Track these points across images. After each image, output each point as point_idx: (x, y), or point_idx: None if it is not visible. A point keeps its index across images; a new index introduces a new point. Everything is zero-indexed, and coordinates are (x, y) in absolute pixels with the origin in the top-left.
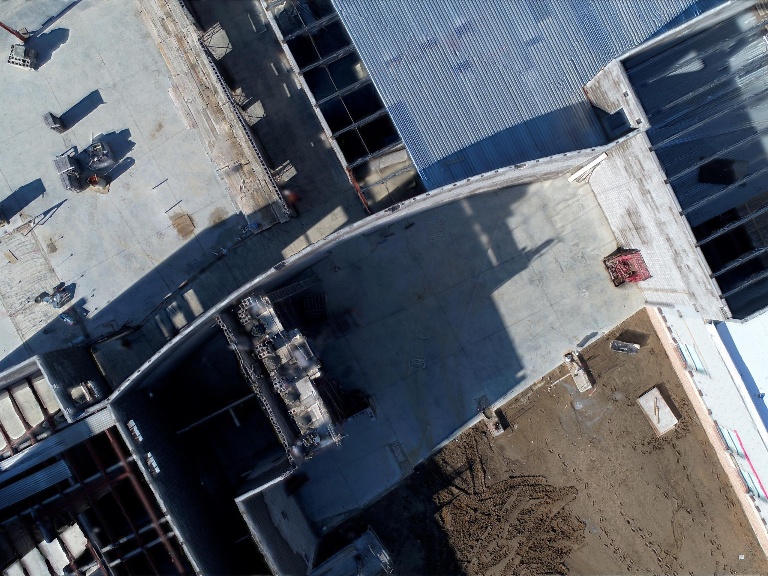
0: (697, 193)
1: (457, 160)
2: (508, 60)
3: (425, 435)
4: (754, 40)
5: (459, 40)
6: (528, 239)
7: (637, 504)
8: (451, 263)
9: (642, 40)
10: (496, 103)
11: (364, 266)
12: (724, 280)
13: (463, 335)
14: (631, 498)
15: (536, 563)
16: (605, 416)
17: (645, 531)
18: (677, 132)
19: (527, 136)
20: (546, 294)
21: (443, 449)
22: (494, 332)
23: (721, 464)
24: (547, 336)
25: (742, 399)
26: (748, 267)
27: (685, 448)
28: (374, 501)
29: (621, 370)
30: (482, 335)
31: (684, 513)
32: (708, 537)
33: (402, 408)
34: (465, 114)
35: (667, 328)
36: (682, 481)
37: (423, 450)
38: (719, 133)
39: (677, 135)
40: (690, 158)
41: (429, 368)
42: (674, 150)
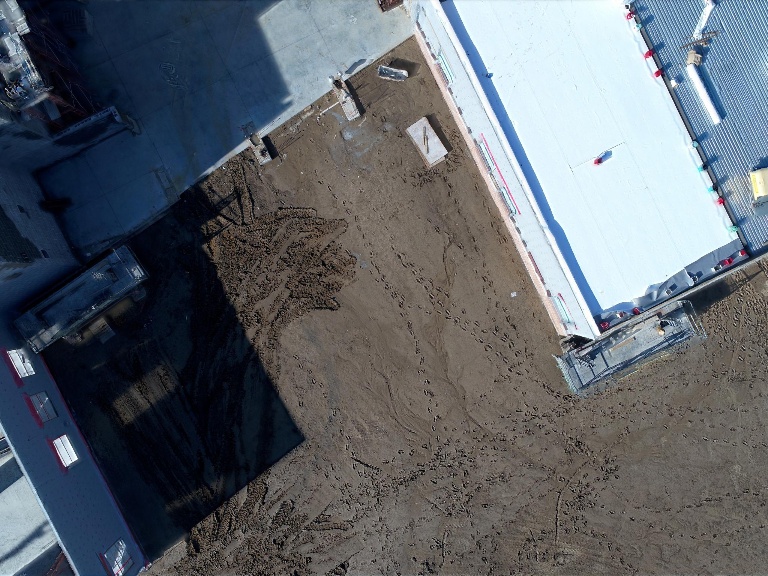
0: None
1: None
2: None
3: (191, 161)
4: None
5: None
6: None
7: (408, 238)
8: None
9: None
10: None
11: None
12: None
13: (230, 60)
14: (402, 232)
15: (306, 297)
16: (375, 147)
17: (416, 266)
18: None
19: None
20: (314, 19)
21: (210, 177)
22: (261, 57)
23: (492, 198)
24: (315, 62)
25: (468, 77)
26: None
27: (456, 181)
28: (141, 230)
29: (391, 100)
30: (249, 60)
31: (456, 248)
32: (480, 273)
33: (168, 134)
34: None
35: (426, 44)
36: (453, 215)
37: (189, 177)
38: None
39: None
40: None
41: (196, 93)
42: None
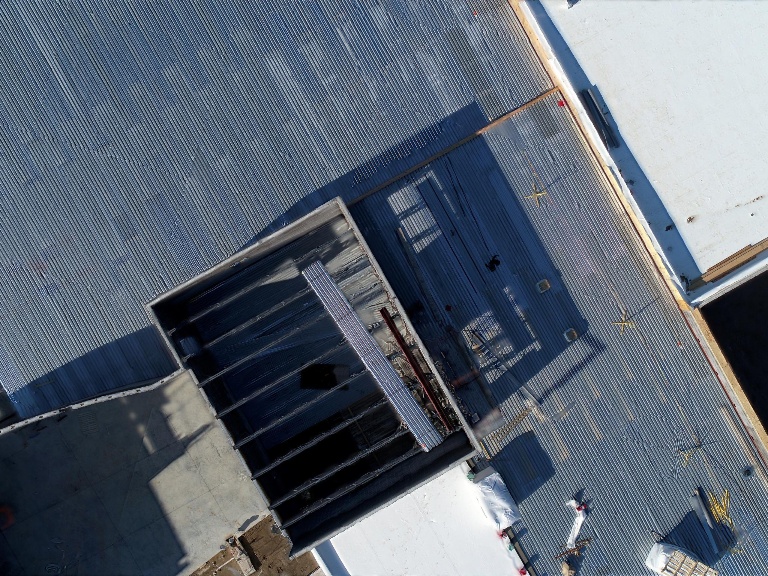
0: (300, 399)
1: (47, 382)
2: (96, 279)
3: None
4: (347, 246)
5: (45, 262)
6: (183, 425)
7: None
8: (106, 453)
9: (231, 253)
10: (86, 323)
11: (18, 460)
12: (287, 509)
13: (122, 525)
14: None
15: None
16: None
17: None
18: (223, 368)
19: (119, 354)
20: (204, 480)
21: None
22: (153, 520)
23: None
24: (207, 522)
25: None
26: (355, 471)
27: None
28: None
29: (286, 551)
30: (141, 524)
31: None
32: None
33: None
34: (54, 336)
35: None
36: None
37: None
38: (318, 339)
39: (222, 372)
40: (291, 365)
41: (89, 560)
42: (274, 358)
